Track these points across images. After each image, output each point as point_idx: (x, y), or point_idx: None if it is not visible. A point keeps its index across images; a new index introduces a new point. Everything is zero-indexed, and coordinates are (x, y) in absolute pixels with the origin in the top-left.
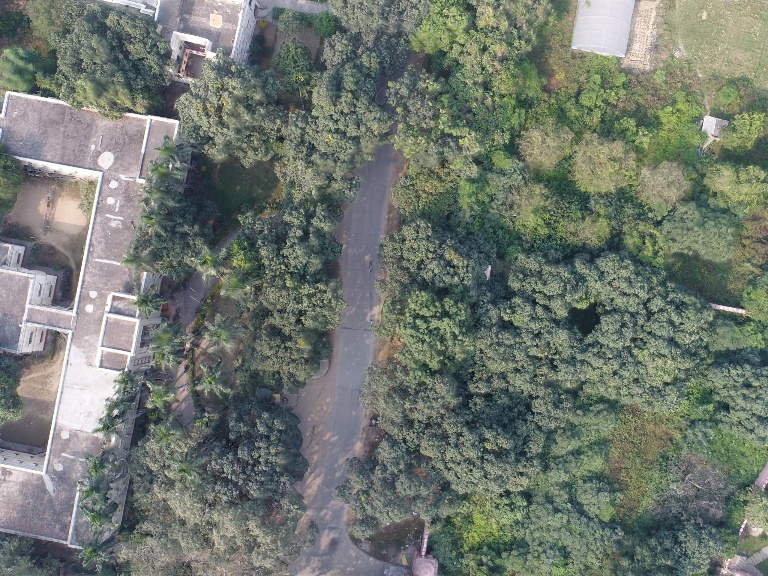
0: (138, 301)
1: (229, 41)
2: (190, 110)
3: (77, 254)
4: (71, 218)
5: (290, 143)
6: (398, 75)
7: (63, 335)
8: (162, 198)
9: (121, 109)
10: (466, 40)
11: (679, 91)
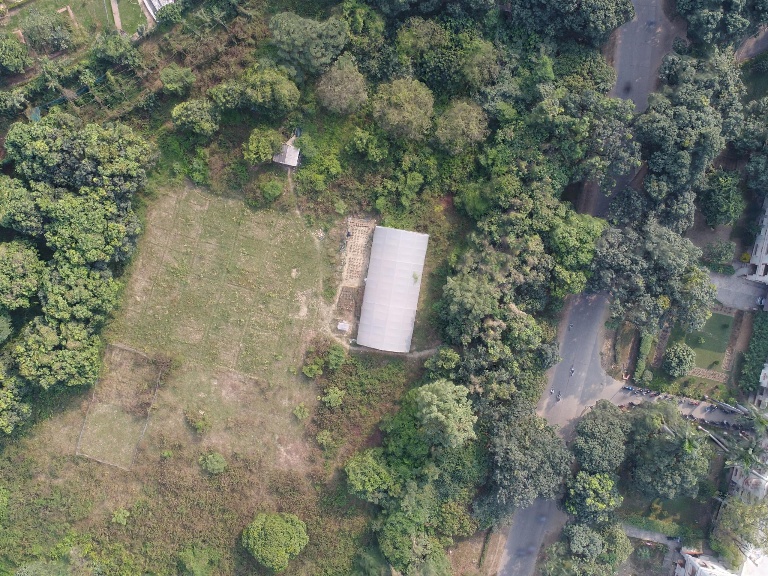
0: None
1: None
2: None
3: None
4: None
5: (738, 108)
6: (603, 209)
7: None
8: None
9: None
10: (554, 219)
11: None
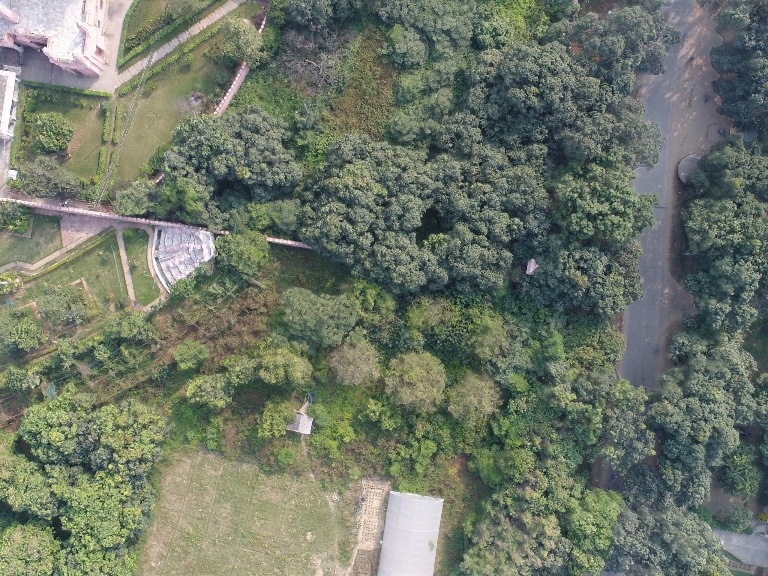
0: None
1: None
2: None
3: None
4: None
5: (750, 390)
6: None
7: None
8: None
9: None
10: (570, 501)
11: None
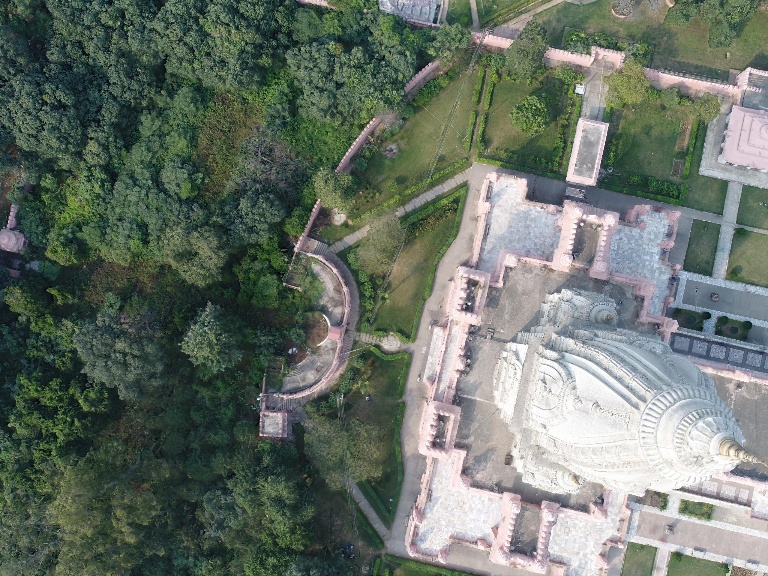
0: None
1: None
2: None
3: None
4: None
5: None
6: None
7: None
8: None
9: None
10: None
11: None
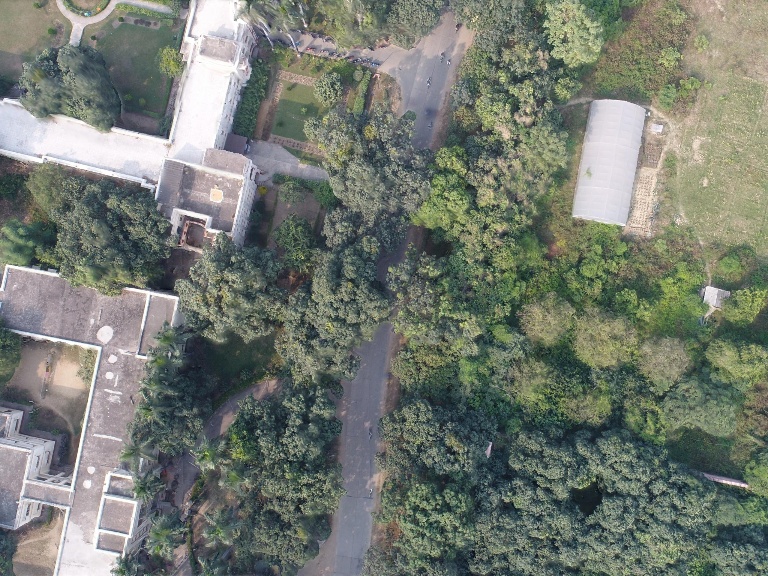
0: (136, 489)
1: (229, 216)
2: (190, 298)
3: (75, 418)
4: (70, 382)
5: (290, 324)
6: None
7: (60, 510)
8: (161, 388)
9: (121, 286)
10: (467, 221)
11: (680, 261)
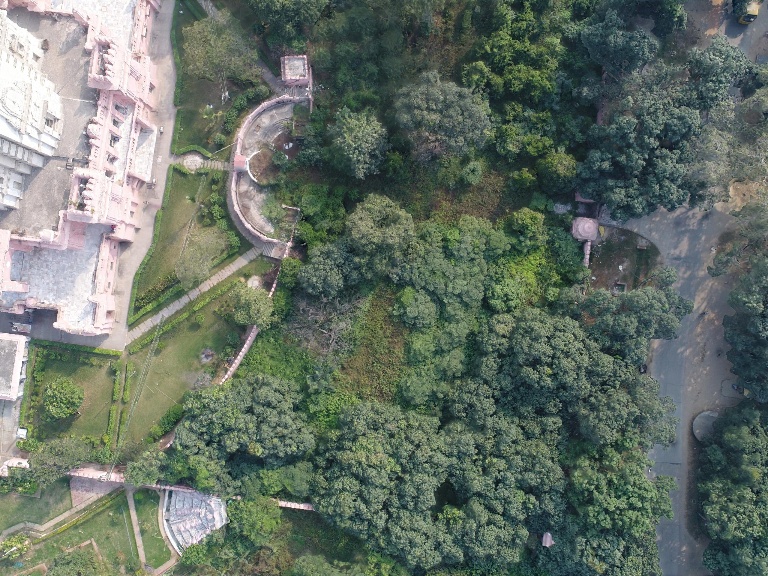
0: None
1: None
2: None
3: None
4: None
5: None
6: None
7: None
8: None
9: None
10: None
11: None
